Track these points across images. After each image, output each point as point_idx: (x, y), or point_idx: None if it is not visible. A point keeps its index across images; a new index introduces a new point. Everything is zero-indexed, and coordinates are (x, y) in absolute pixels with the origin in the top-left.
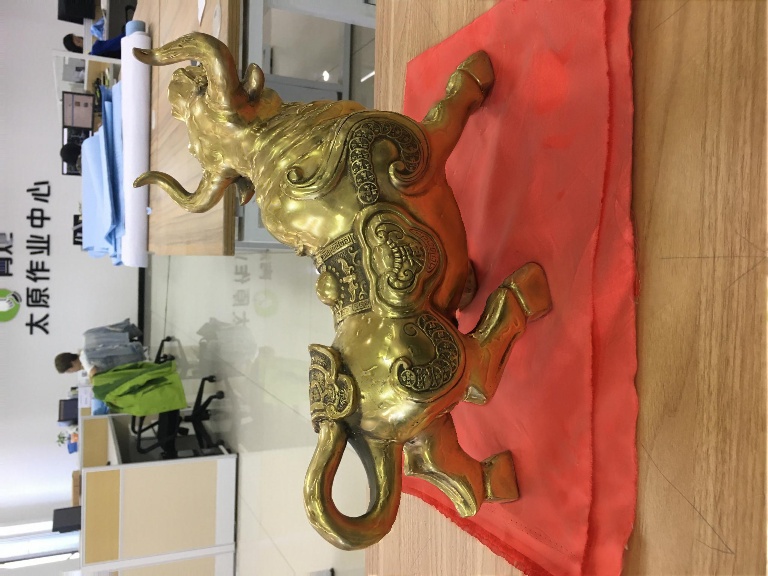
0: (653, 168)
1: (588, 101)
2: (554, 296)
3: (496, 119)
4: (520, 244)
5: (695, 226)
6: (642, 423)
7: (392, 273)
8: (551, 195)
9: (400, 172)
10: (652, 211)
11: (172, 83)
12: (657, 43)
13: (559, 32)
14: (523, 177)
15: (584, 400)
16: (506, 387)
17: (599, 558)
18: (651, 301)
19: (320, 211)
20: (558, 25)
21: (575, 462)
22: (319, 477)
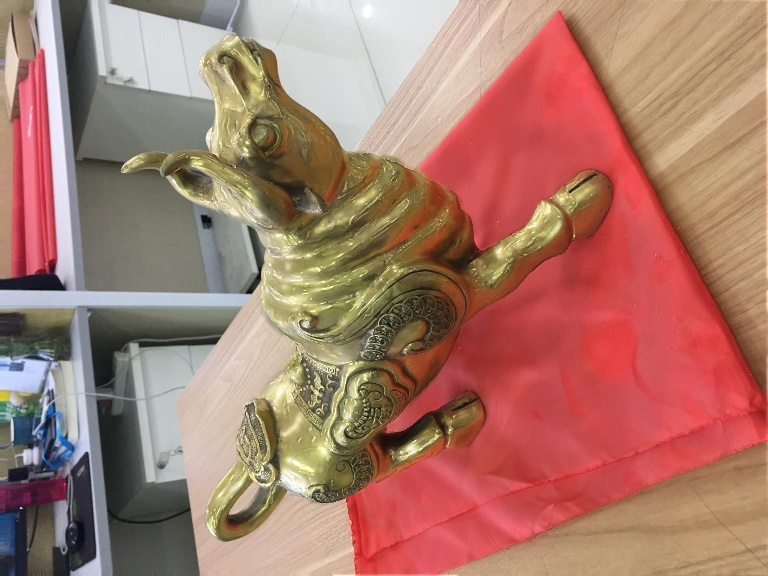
0: (591, 527)
1: (613, 421)
2: (476, 443)
3: (560, 267)
4: (485, 390)
5: None
6: (457, 569)
7: (352, 425)
8: (533, 402)
9: (415, 350)
10: (565, 537)
11: (210, 65)
12: (682, 497)
13: (650, 368)
14: (531, 350)
15: (441, 512)
16: (407, 418)
17: (388, 560)
18: (516, 555)
19: (318, 348)
20: (655, 365)
21: (412, 516)
22: (223, 507)
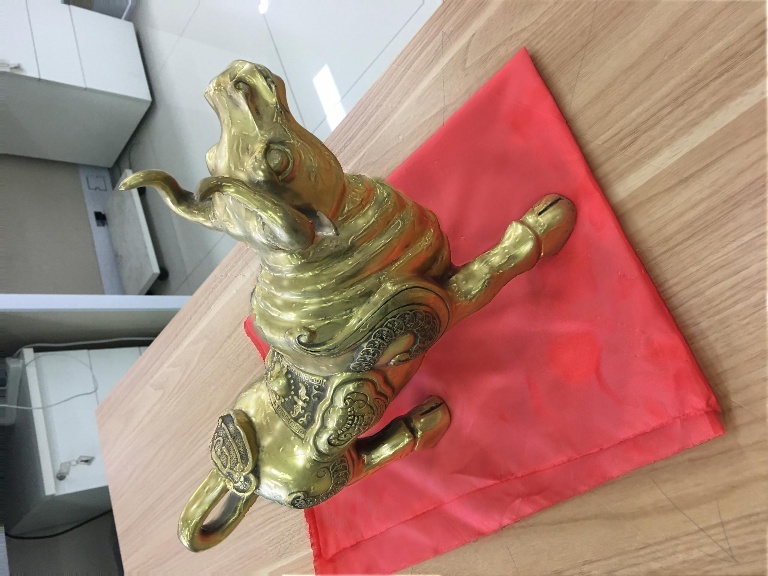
0: (556, 518)
1: (577, 422)
2: (441, 444)
3: (526, 282)
4: (451, 395)
5: (537, 572)
6: (422, 564)
7: (336, 433)
8: (499, 405)
9: None
10: (530, 528)
11: (224, 90)
12: (642, 486)
13: (614, 374)
14: (497, 357)
15: (404, 511)
16: None
17: (348, 559)
18: (482, 547)
19: (310, 361)
20: (619, 371)
21: (373, 516)
22: (199, 518)
